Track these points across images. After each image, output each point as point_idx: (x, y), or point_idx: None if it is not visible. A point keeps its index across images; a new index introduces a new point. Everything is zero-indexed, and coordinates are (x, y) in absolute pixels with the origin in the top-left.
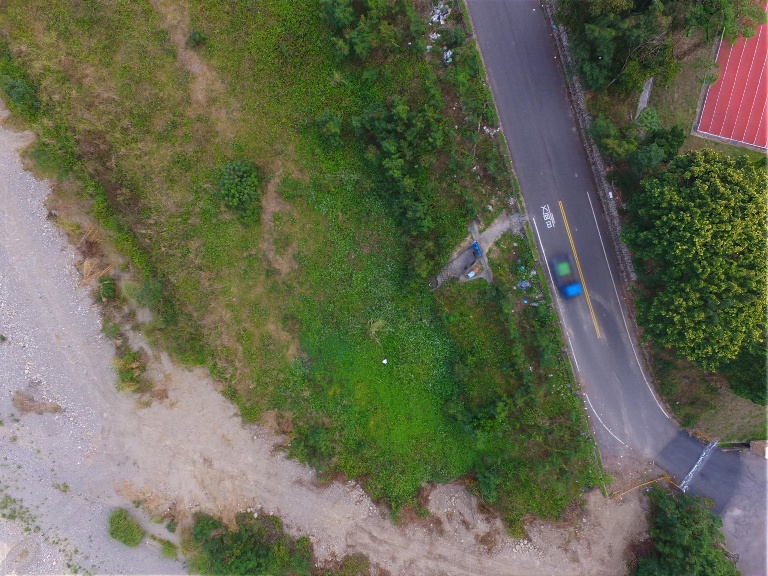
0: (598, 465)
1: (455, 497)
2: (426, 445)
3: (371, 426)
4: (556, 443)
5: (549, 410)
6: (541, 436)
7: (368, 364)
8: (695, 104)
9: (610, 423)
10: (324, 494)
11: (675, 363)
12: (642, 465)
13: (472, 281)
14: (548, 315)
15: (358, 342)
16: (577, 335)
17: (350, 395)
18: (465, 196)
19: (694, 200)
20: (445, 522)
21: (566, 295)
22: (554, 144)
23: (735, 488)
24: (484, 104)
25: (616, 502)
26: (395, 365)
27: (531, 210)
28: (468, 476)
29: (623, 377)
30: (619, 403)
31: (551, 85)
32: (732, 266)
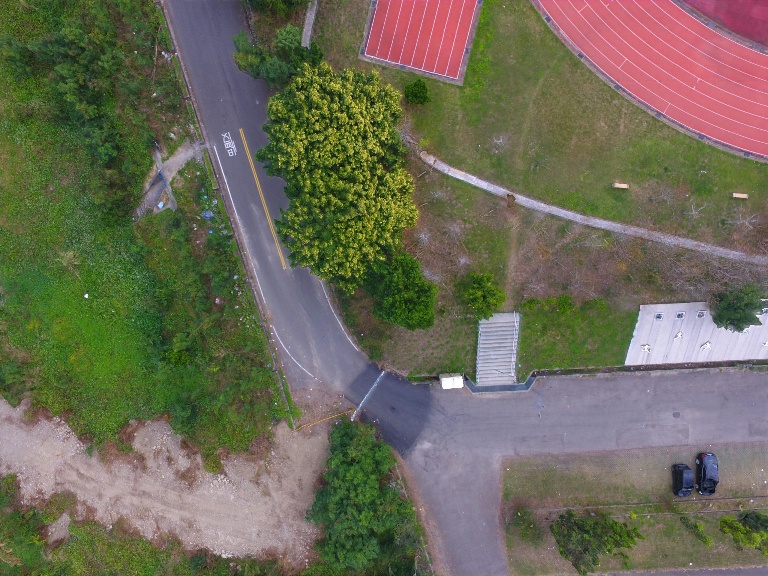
0: (285, 397)
1: (167, 435)
2: (129, 381)
3: (72, 361)
4: (232, 373)
5: (235, 342)
6: (218, 366)
7: (68, 298)
8: (362, 27)
9: (298, 355)
10: (34, 432)
11: None
12: (332, 398)
13: (162, 212)
14: (227, 244)
15: (57, 276)
16: (262, 266)
17: (49, 330)
18: (132, 120)
19: (295, 111)
20: (149, 458)
21: (249, 225)
22: (233, 70)
23: (425, 421)
24: (159, 28)
25: (304, 435)
26: (96, 299)
27: (211, 138)
28: None
29: (310, 309)
30: (307, 335)
31: (229, 9)
32: (331, 178)
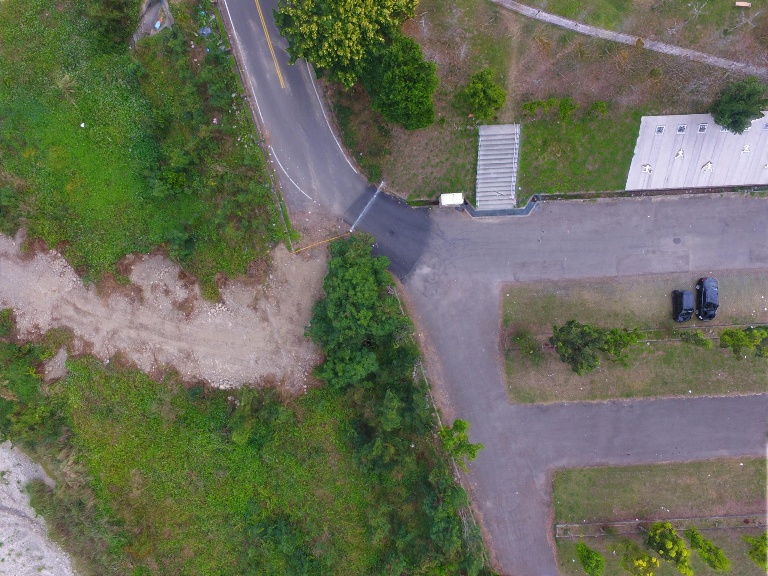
0: (283, 219)
1: (164, 271)
2: (126, 211)
3: (68, 191)
4: None
5: (233, 162)
6: (216, 182)
7: (64, 127)
8: None
9: (297, 177)
10: (30, 267)
11: (352, 108)
12: (331, 222)
13: (159, 32)
14: (225, 59)
15: (53, 103)
16: (260, 84)
17: (45, 158)
18: None
19: None
20: (146, 290)
21: (248, 42)
22: None
23: (425, 246)
24: None
25: (302, 258)
26: (92, 128)
27: None
28: (168, 243)
29: (309, 129)
30: (305, 156)
31: None
32: None
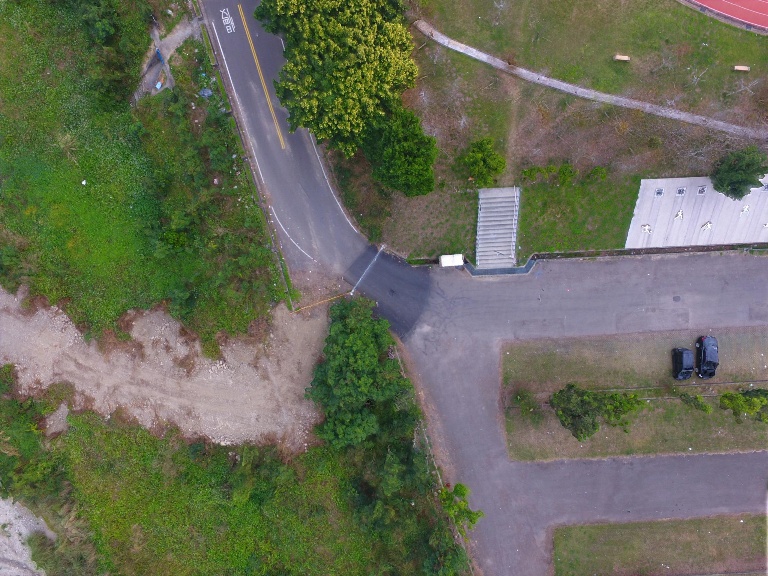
0: (284, 279)
1: (165, 326)
2: (127, 268)
3: (69, 248)
4: None
5: (234, 223)
6: (216, 244)
7: (65, 184)
8: None
9: (297, 237)
10: (31, 322)
11: (353, 170)
12: (331, 281)
13: (160, 93)
14: (226, 121)
15: (54, 161)
16: (260, 145)
17: (47, 216)
18: None
19: None
20: (147, 347)
21: (248, 103)
22: None
23: (425, 304)
24: None
25: (303, 317)
26: (93, 186)
27: (210, 14)
28: (169, 299)
29: (309, 189)
30: (306, 216)
31: None
32: (330, 23)
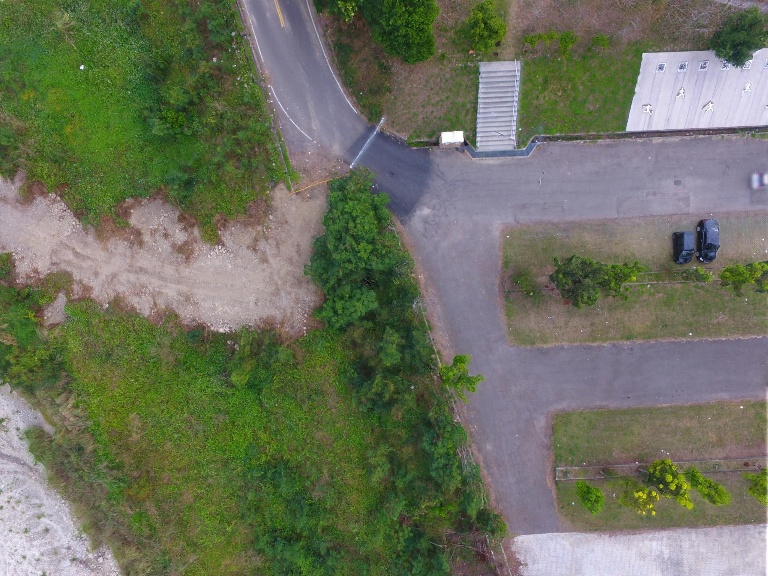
0: (283, 159)
1: (164, 216)
2: (125, 154)
3: (67, 133)
4: None
5: (233, 102)
6: (215, 119)
7: (63, 68)
8: None
9: (297, 117)
10: (29, 212)
11: (353, 46)
12: (331, 162)
13: None
14: None
15: (52, 45)
16: (260, 23)
17: (44, 100)
18: None
19: None
20: (146, 234)
21: None
22: None
23: (425, 187)
24: None
25: (302, 198)
26: (91, 70)
27: None
28: None
29: (309, 69)
30: (305, 96)
31: None
32: None
